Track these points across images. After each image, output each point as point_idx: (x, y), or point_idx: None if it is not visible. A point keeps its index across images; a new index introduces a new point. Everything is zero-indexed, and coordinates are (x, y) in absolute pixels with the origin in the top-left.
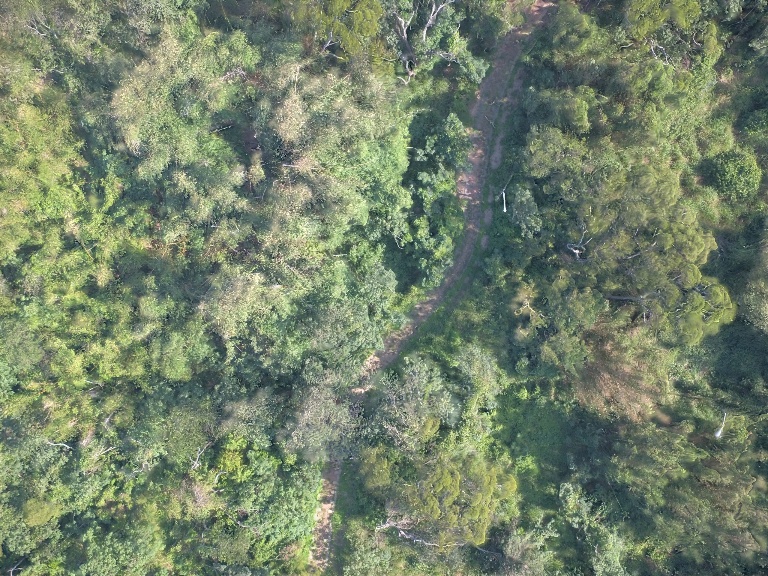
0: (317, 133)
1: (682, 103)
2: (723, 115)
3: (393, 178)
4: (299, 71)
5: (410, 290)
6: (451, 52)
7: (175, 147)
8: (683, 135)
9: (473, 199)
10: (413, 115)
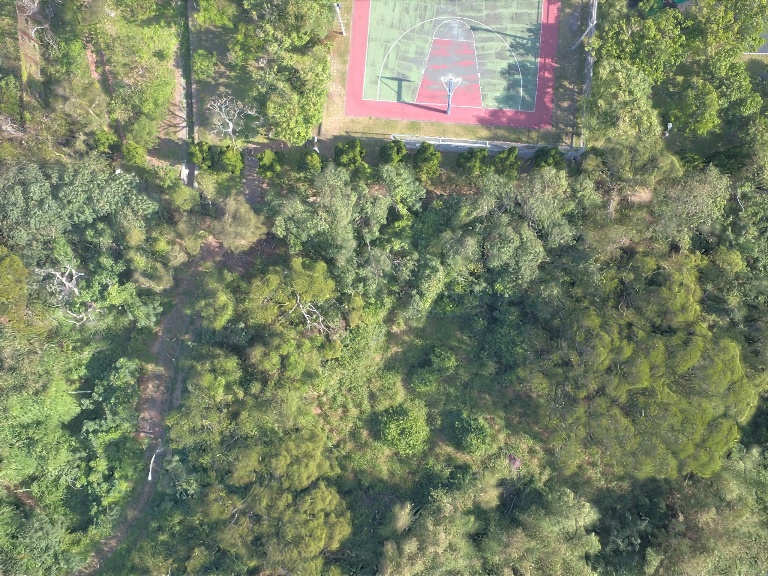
0: None
1: (316, 383)
2: (392, 368)
3: (48, 434)
4: None
5: (86, 531)
6: (111, 303)
7: None
8: (353, 387)
9: (155, 437)
10: (88, 355)
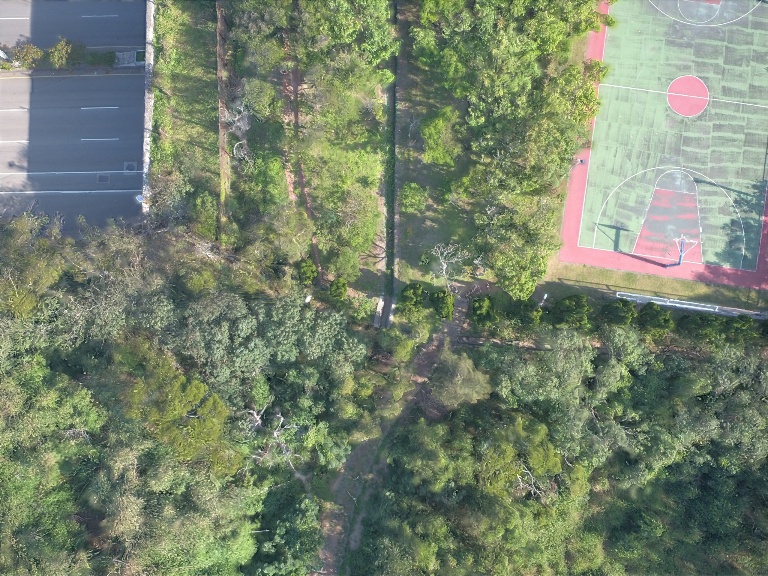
0: (150, 534)
1: (537, 557)
2: (594, 530)
3: None
4: (137, 461)
5: None
6: (306, 445)
7: (8, 507)
8: (551, 546)
9: None
10: None
